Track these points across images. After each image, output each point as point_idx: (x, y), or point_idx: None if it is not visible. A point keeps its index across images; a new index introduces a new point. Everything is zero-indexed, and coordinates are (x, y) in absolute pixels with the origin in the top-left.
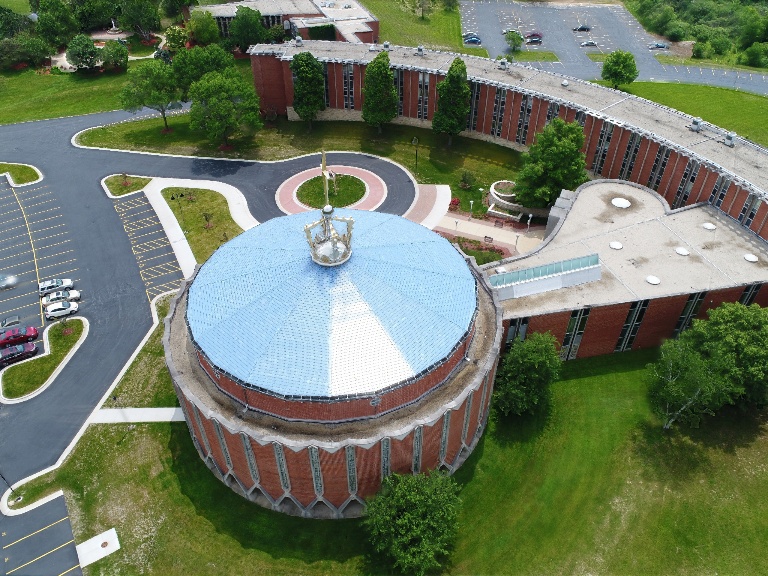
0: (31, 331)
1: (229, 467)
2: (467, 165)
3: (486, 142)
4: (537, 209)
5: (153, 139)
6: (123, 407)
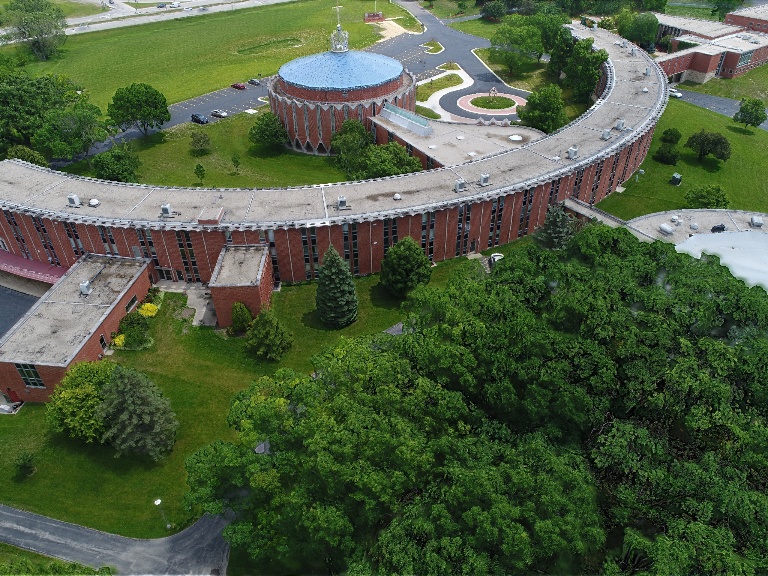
0: None
1: None
2: None
3: None
4: None
5: (498, 60)
6: None
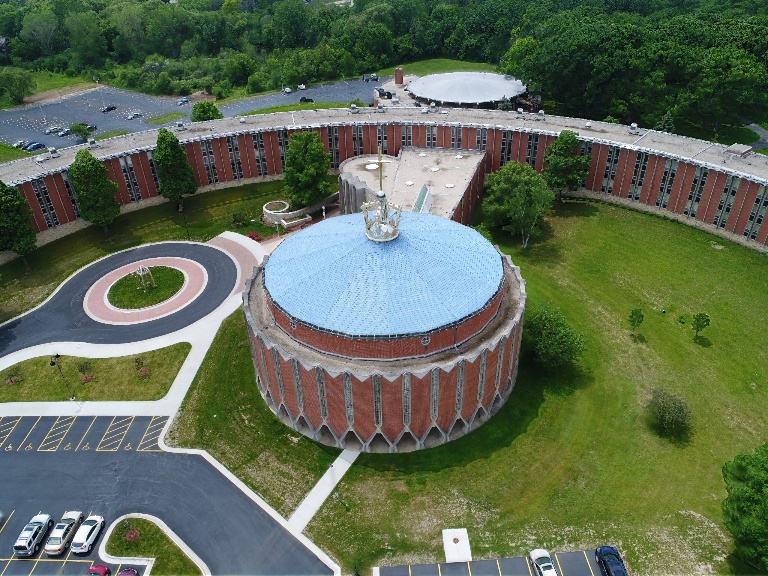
0: (98, 570)
1: (458, 411)
2: (215, 214)
3: (208, 192)
4: (314, 206)
5: None
6: (302, 499)
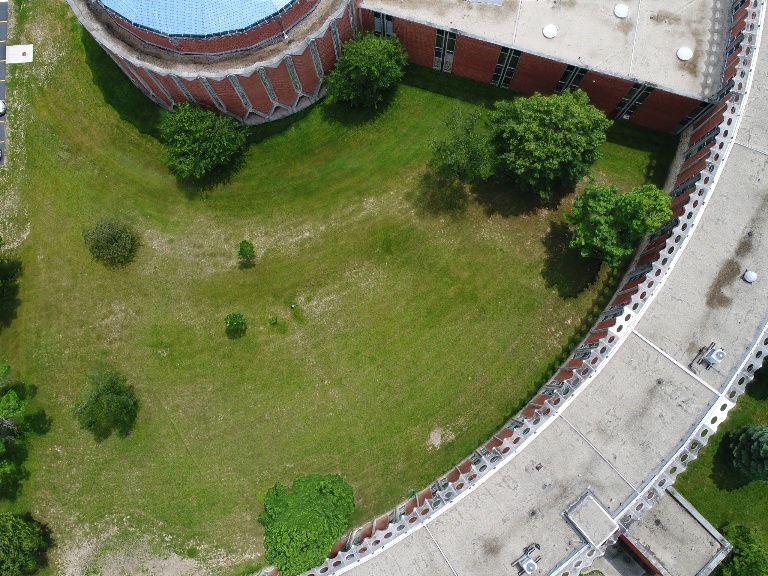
0: None
1: None
2: None
3: None
4: None
5: None
6: None
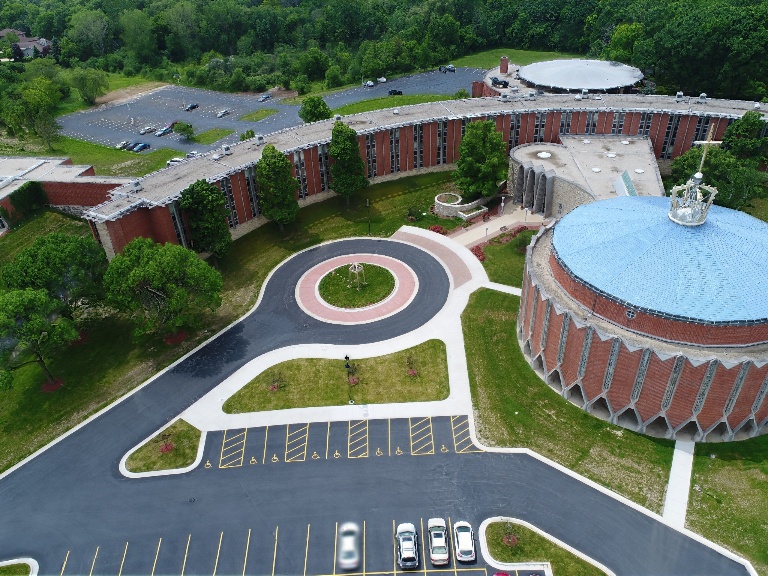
0: None
1: None
2: (382, 208)
3: (367, 187)
4: (486, 197)
5: (62, 402)
6: (664, 493)
